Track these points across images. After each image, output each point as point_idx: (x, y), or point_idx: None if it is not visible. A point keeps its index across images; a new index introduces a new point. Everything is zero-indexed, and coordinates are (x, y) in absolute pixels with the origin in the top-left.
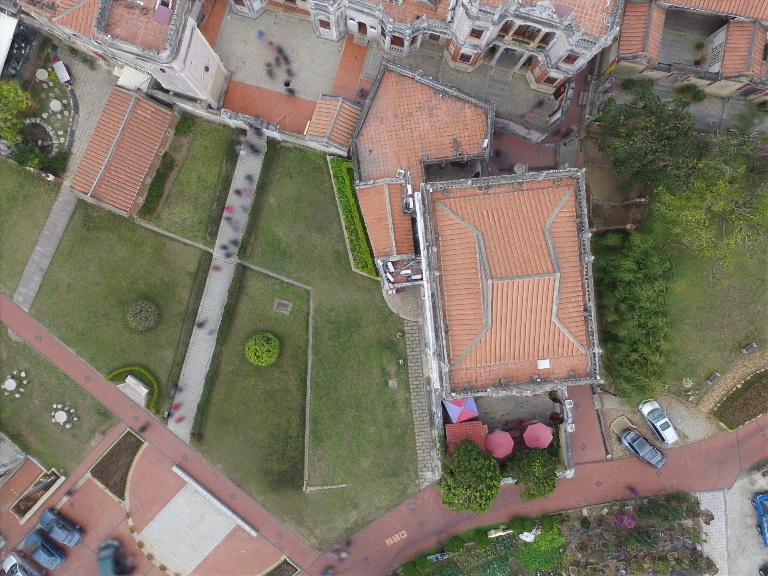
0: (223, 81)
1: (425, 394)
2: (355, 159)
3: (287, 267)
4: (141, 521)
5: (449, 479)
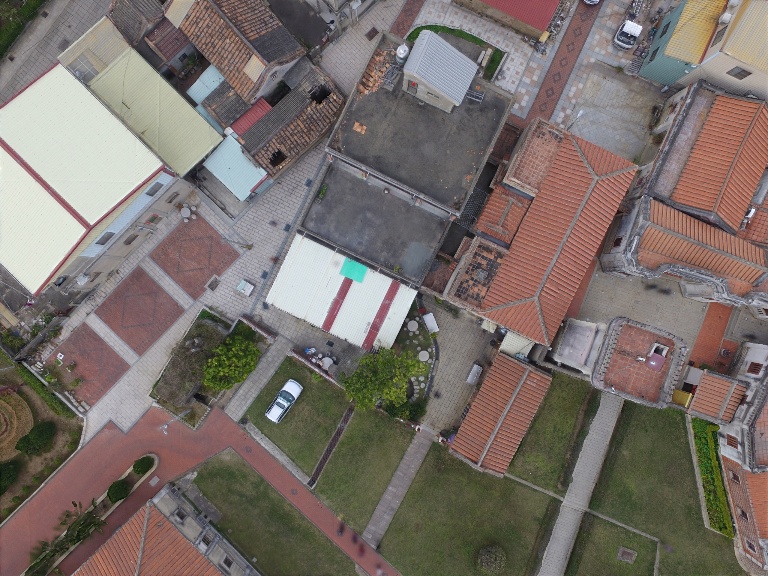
0: None
1: None
2: (754, 447)
3: (636, 518)
4: None
5: None
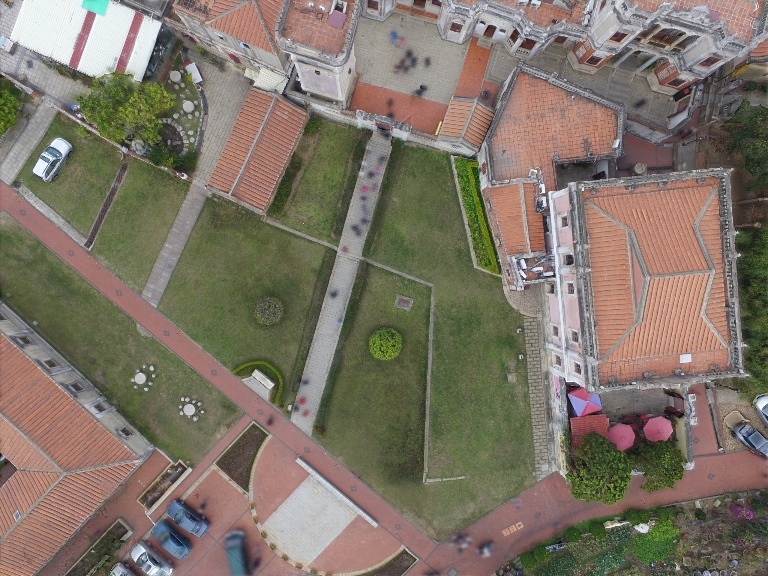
0: (352, 83)
1: (543, 388)
2: (492, 159)
3: (409, 264)
4: (264, 512)
5: (582, 470)
